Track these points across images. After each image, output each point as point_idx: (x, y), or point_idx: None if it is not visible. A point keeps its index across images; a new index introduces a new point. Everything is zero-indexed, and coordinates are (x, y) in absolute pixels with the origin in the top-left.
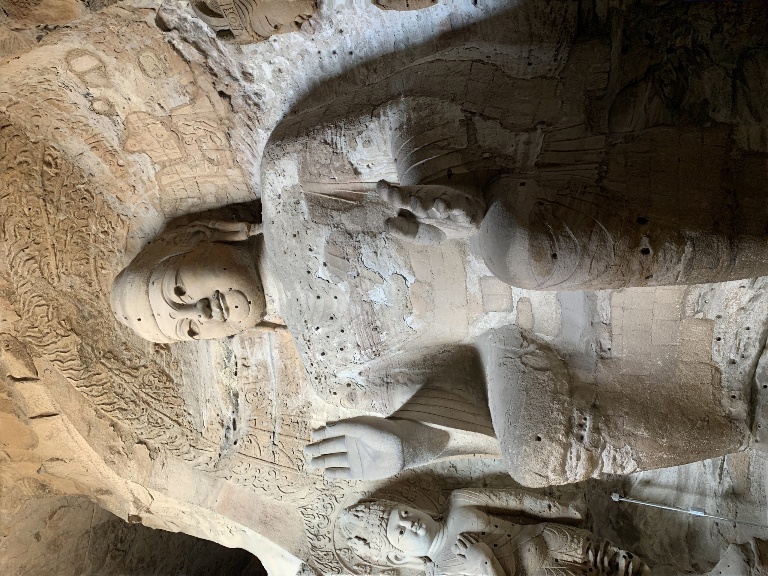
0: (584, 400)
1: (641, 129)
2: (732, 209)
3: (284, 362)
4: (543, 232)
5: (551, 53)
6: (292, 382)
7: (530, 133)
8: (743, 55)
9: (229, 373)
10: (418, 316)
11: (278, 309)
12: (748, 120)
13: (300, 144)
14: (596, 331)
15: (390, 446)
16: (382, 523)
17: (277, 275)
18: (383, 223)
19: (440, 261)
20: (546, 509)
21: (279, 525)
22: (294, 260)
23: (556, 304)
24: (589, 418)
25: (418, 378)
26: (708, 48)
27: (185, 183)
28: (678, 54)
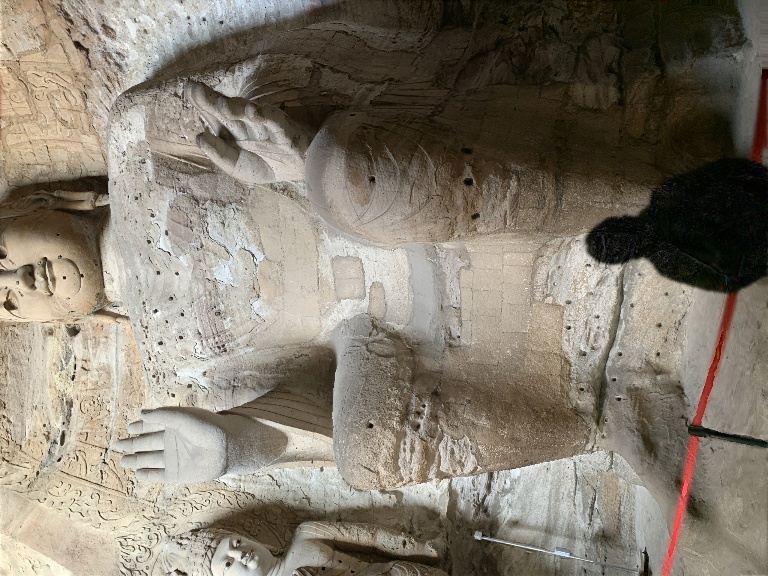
0: (425, 387)
1: (484, 86)
2: (560, 150)
3: (130, 367)
4: (362, 152)
5: (417, 36)
6: (136, 391)
7: (376, 85)
8: (589, 37)
9: (65, 376)
10: (266, 301)
11: (118, 291)
12: (585, 81)
13: (149, 95)
14: (446, 316)
15: (212, 440)
16: (207, 552)
17: (118, 249)
18: (235, 193)
19: (292, 238)
20: (400, 545)
21: (89, 556)
22: (135, 228)
23: (408, 289)
24: (428, 405)
25: (268, 382)
26: (557, 29)
27: (34, 146)
28: (529, 32)
